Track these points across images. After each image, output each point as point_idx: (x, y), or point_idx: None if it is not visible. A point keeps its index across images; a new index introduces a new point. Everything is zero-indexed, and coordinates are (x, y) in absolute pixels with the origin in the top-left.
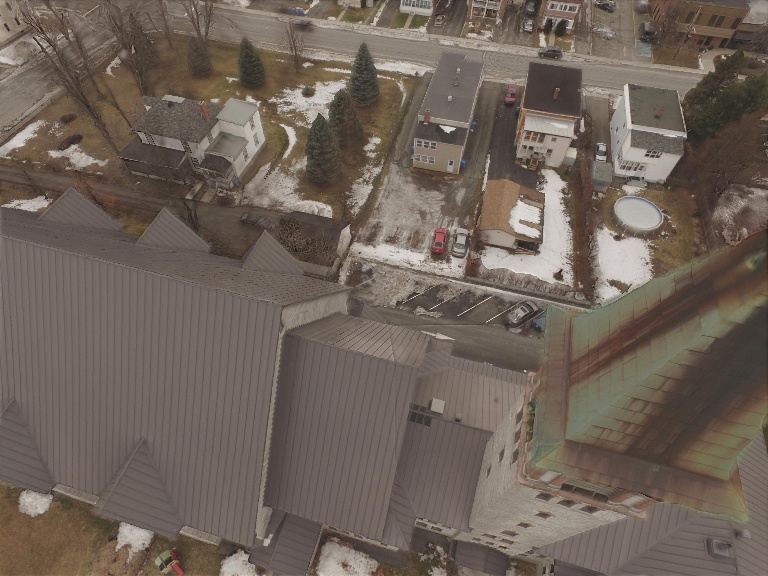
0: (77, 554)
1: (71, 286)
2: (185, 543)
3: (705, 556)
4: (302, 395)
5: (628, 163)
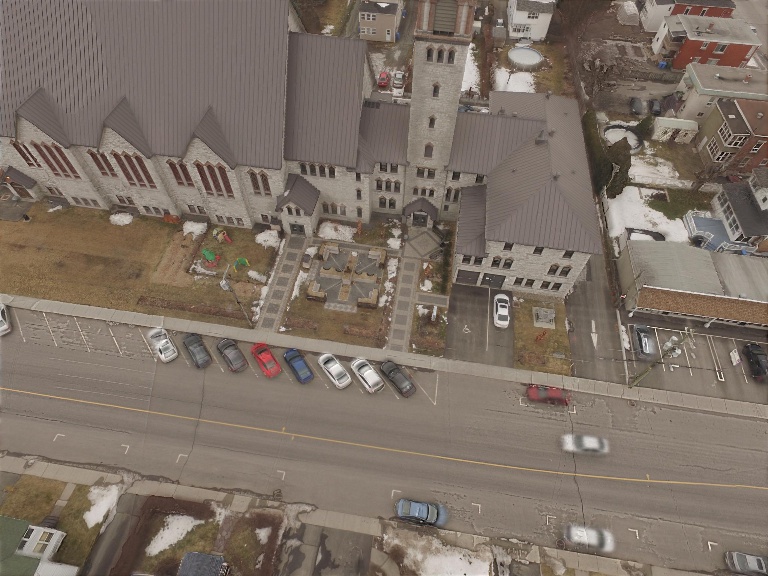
0: (158, 239)
1: (163, 8)
2: (229, 229)
3: (534, 146)
4: (302, 73)
5: (517, 26)
